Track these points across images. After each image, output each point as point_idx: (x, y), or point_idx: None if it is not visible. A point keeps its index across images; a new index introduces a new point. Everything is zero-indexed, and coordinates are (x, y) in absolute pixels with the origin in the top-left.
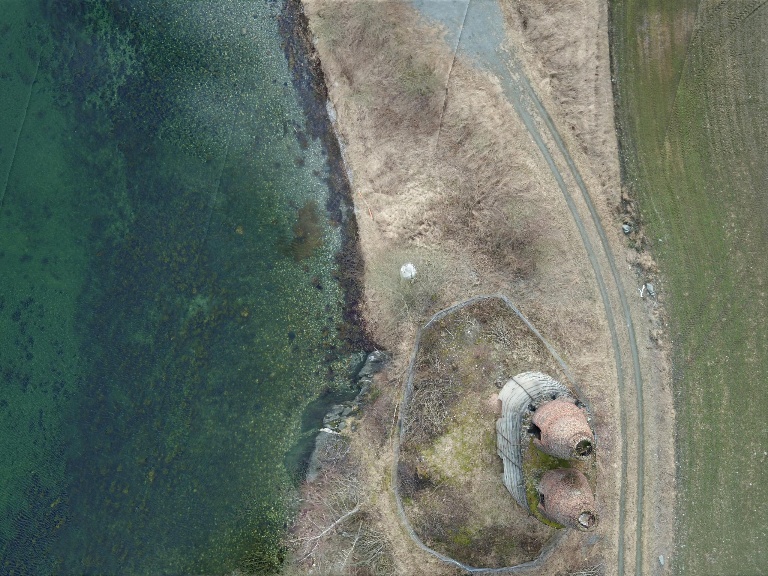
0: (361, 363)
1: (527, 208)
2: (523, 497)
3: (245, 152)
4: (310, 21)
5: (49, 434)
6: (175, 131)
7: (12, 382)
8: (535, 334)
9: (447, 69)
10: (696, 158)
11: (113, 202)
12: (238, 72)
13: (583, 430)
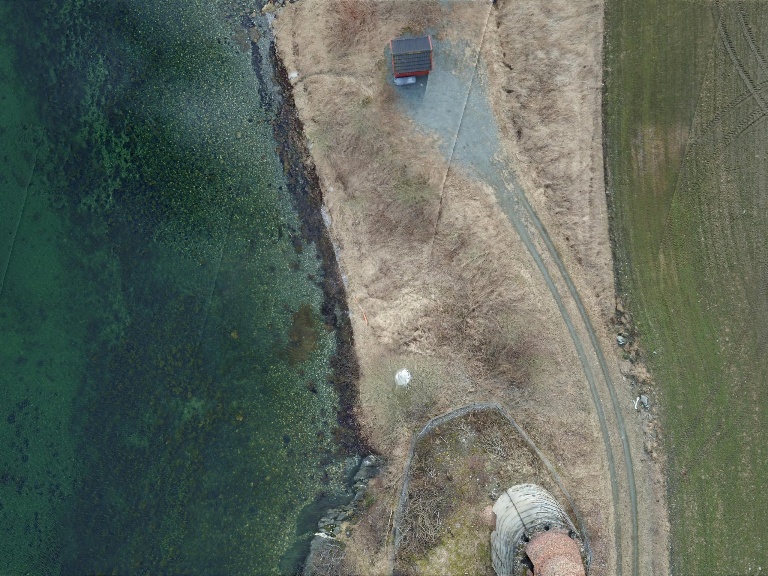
0: (356, 467)
1: (521, 318)
2: None
3: (240, 255)
4: (305, 126)
5: (44, 536)
6: (170, 234)
7: (7, 484)
8: (529, 444)
9: (441, 179)
10: (690, 271)
11: (108, 304)
12: (233, 176)
13: None
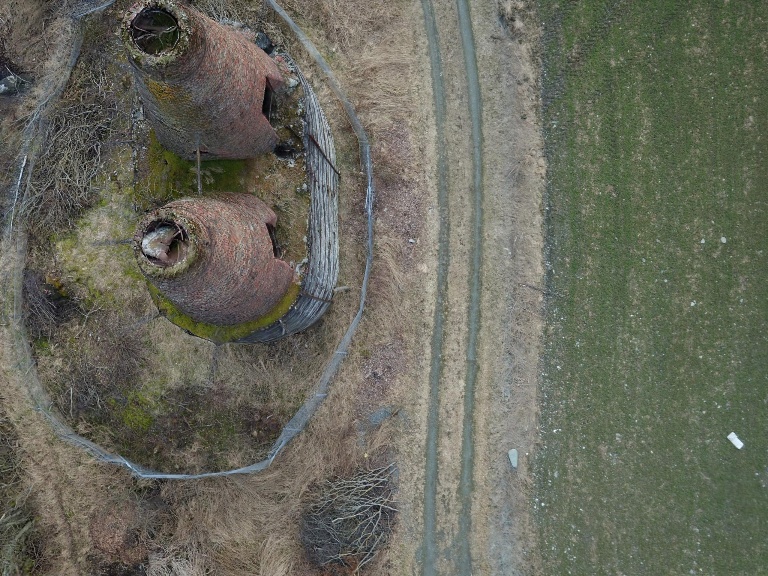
0: None
1: None
2: None
3: None
4: None
5: None
6: None
7: None
8: (279, 17)
9: None
10: None
11: None
12: None
13: None
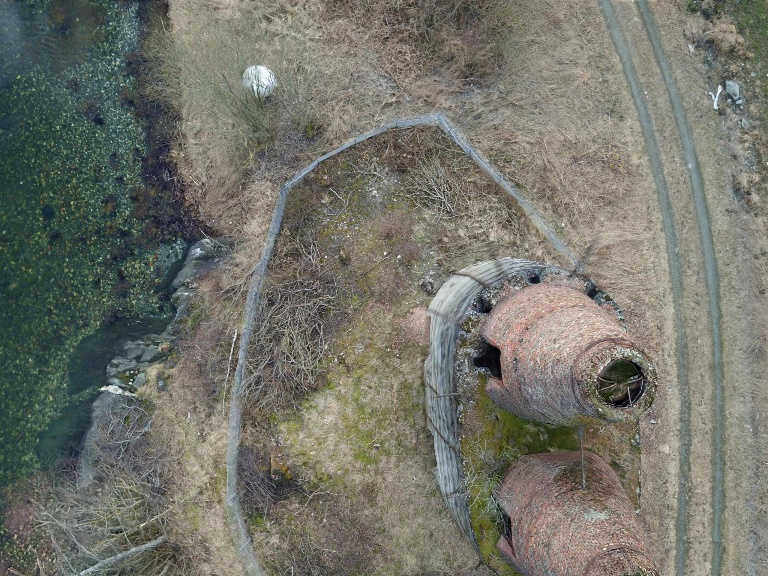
0: (177, 262)
1: None
2: (465, 521)
3: None
4: None
5: None
6: None
7: None
8: (502, 189)
9: None
10: None
11: None
12: None
13: (615, 333)
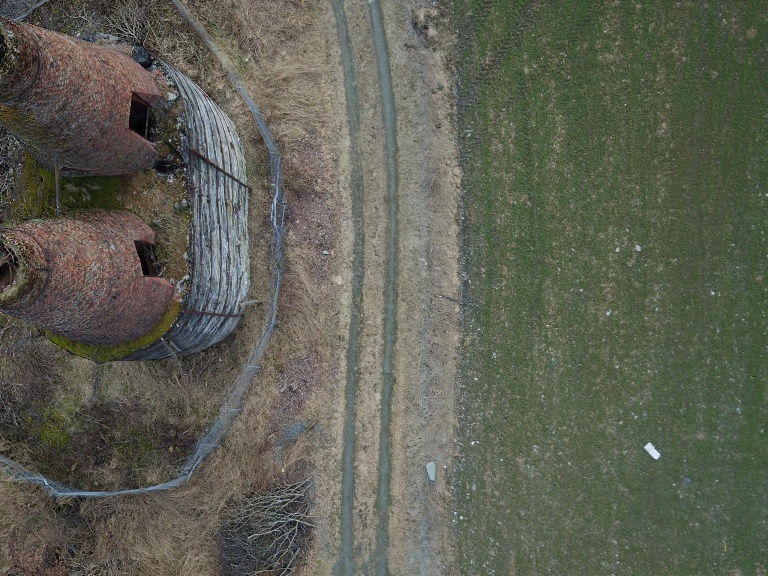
0: None
1: None
2: None
3: None
4: None
5: None
6: None
7: None
8: (193, 27)
9: None
10: None
11: None
12: None
13: None
